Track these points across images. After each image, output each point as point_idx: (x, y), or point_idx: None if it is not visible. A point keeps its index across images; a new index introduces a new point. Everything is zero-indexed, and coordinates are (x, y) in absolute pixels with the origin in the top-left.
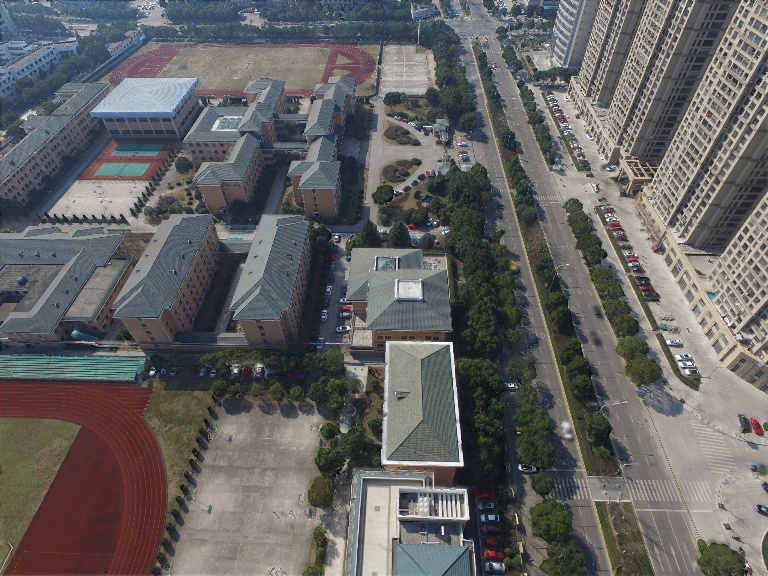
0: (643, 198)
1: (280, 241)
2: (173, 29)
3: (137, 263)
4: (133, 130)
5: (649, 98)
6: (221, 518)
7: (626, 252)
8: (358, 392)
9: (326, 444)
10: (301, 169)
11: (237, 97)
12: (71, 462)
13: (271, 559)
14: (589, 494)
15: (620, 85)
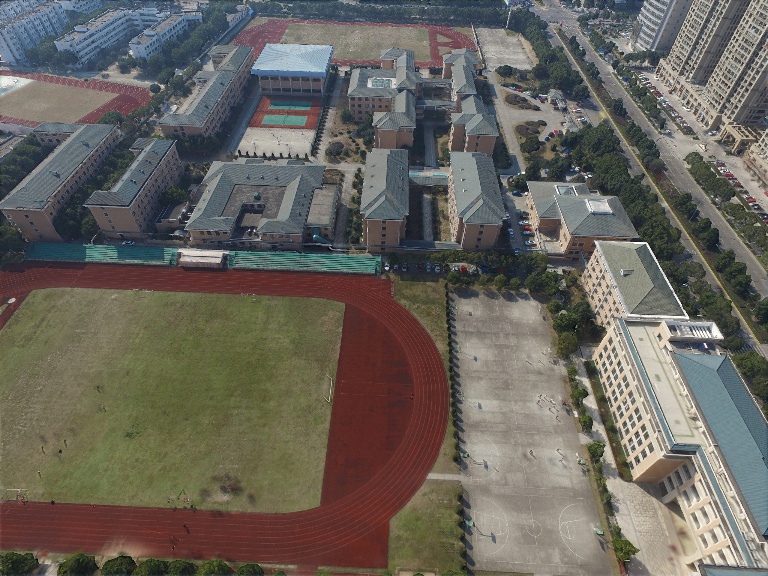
0: (753, 154)
1: (481, 168)
2: (279, 5)
3: (364, 182)
4: (283, 88)
5: (758, 71)
6: (487, 364)
7: (744, 195)
8: (560, 286)
9: (549, 319)
10: (464, 119)
11: (362, 65)
12: (350, 326)
13: (537, 389)
14: (765, 355)
15: (722, 62)
